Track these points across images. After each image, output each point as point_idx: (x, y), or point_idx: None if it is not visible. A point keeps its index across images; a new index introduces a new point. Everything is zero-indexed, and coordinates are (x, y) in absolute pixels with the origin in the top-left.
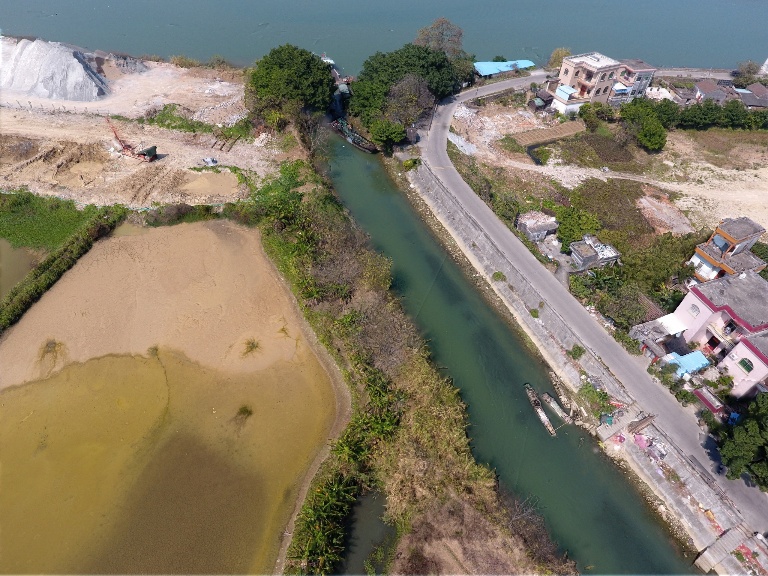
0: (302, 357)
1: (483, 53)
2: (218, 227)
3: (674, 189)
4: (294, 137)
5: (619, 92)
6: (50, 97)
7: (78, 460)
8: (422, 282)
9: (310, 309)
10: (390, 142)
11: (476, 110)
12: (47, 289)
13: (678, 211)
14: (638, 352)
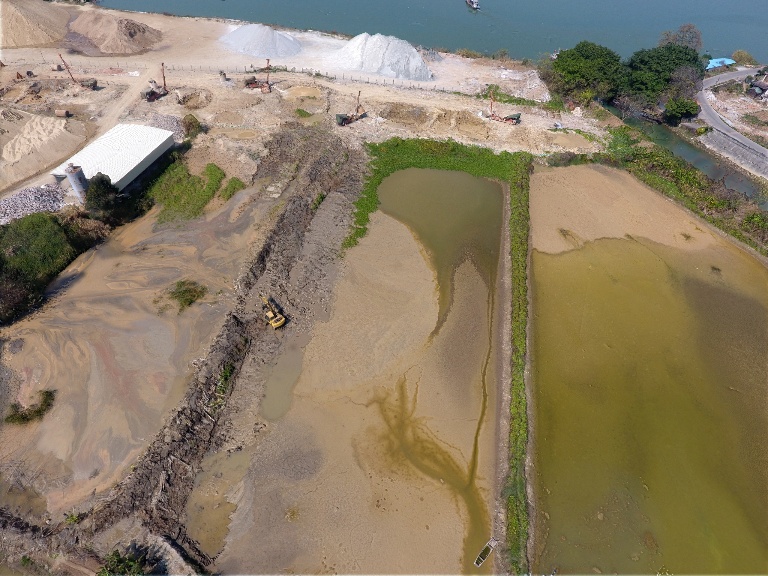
0: (723, 243)
1: None
2: (598, 168)
3: None
4: (604, 110)
5: None
6: (397, 77)
7: (642, 288)
8: (763, 205)
9: (711, 216)
10: (683, 115)
11: (714, 95)
12: None
13: None
14: None
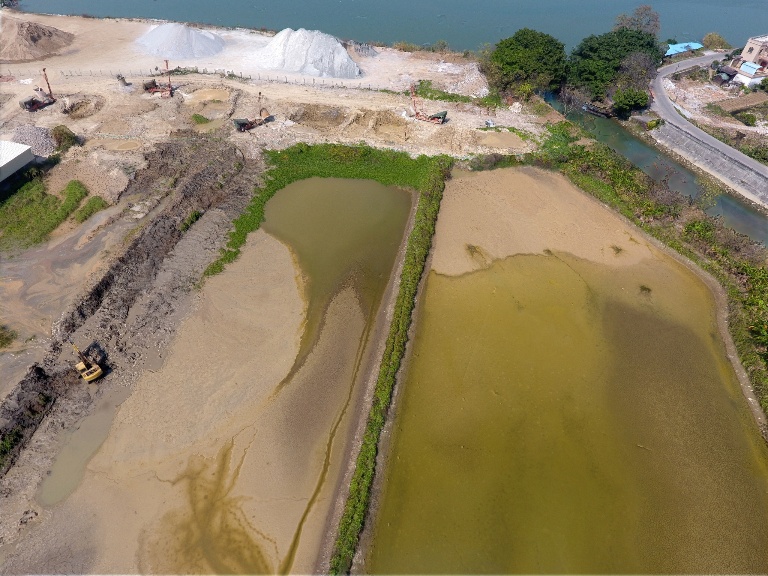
0: (659, 256)
1: None
2: (528, 171)
3: None
4: (545, 104)
5: None
6: (321, 76)
7: (552, 315)
8: (713, 209)
9: (648, 224)
10: (632, 107)
11: (674, 83)
12: (438, 212)
13: None
14: None
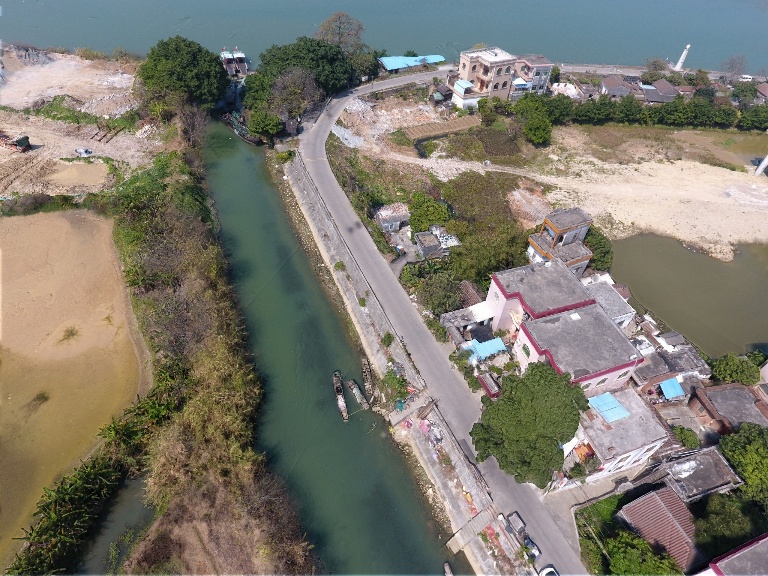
0: (118, 344)
1: (393, 48)
2: (74, 217)
3: (550, 182)
4: (176, 129)
5: (519, 87)
6: None
7: None
8: (265, 272)
9: (138, 297)
10: (269, 134)
11: (373, 104)
12: None
13: (547, 204)
14: (443, 339)
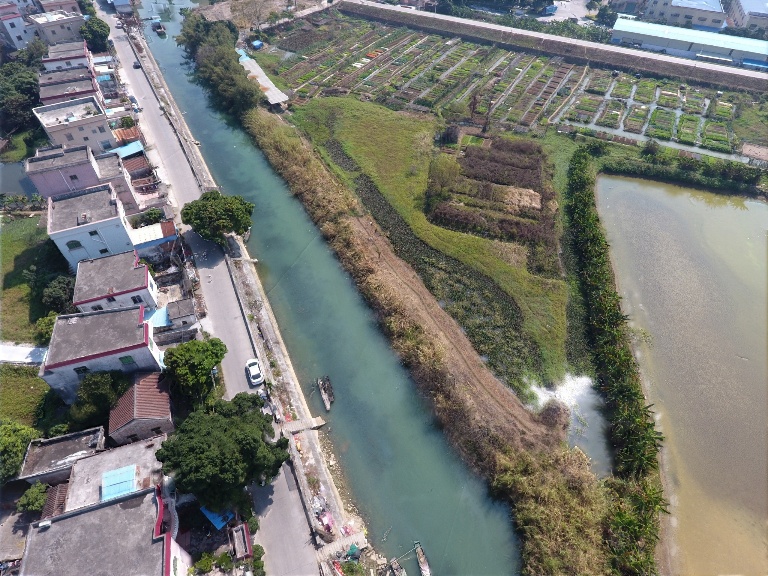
0: None
1: None
2: None
3: None
4: None
5: None
6: None
7: None
8: None
9: None
10: None
11: None
12: None
13: None
14: None
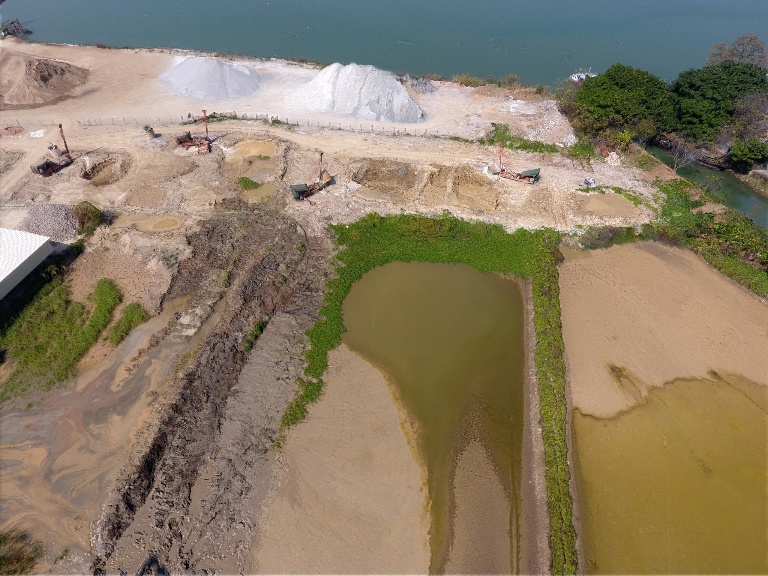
0: None
1: None
2: (651, 248)
3: None
4: (649, 156)
5: None
6: (378, 119)
7: (753, 484)
8: None
9: None
10: (755, 160)
11: None
12: None
13: None
14: None
